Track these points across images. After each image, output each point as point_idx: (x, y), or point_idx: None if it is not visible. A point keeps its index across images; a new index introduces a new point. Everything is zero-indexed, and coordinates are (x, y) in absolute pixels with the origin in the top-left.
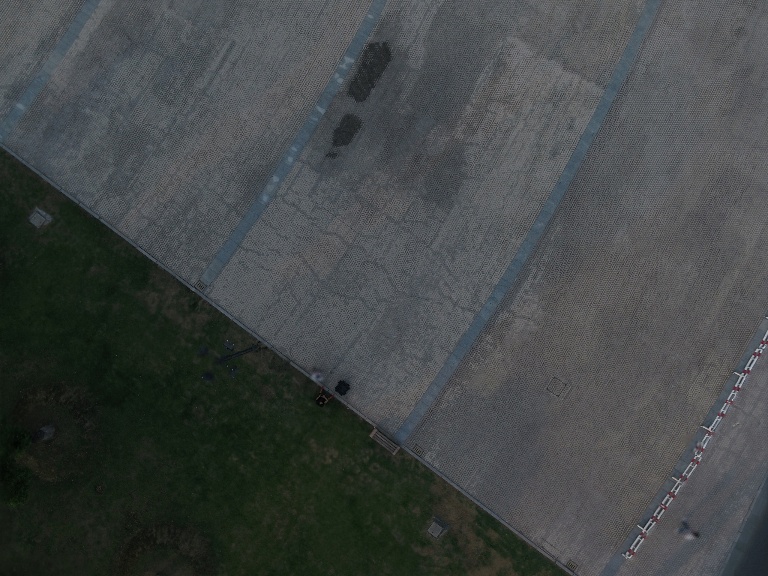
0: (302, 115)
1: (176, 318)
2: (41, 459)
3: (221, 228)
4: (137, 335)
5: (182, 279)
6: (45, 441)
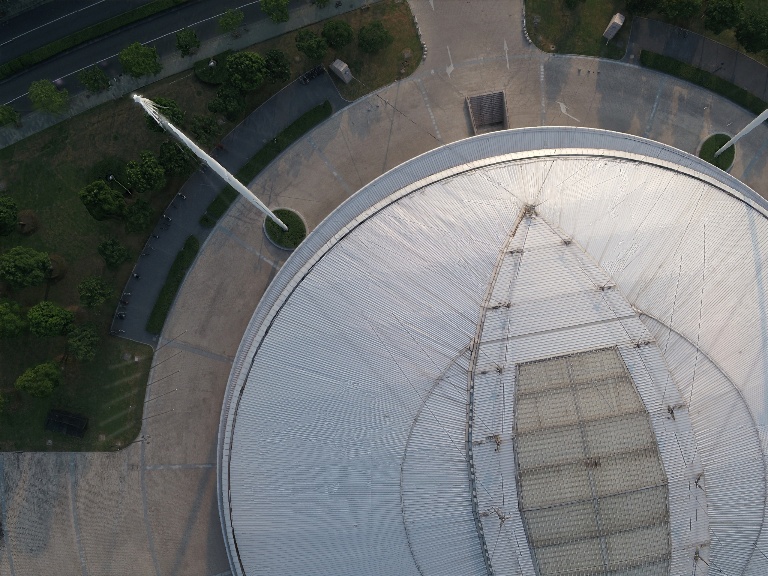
0: (7, 509)
1: (2, 443)
2: (4, 394)
3: (7, 470)
4: (7, 433)
5: (7, 453)
6: (6, 398)
